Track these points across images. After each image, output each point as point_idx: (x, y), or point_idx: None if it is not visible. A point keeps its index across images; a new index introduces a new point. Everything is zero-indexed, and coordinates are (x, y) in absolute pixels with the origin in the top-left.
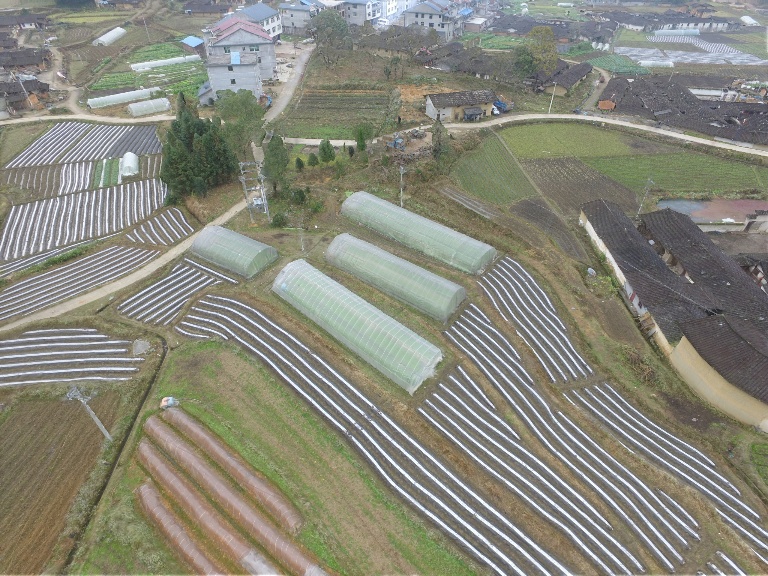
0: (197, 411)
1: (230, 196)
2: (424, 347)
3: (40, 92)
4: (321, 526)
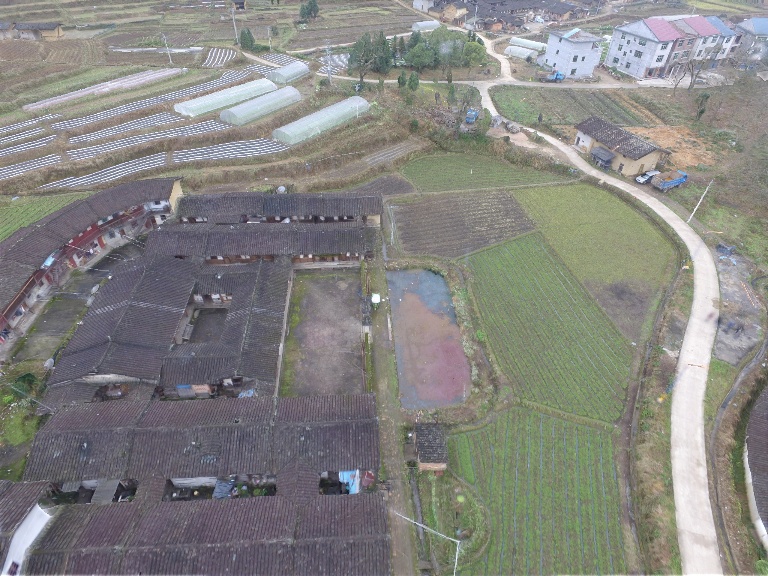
0: None
1: None
2: (192, 104)
3: (511, 25)
4: (121, 90)
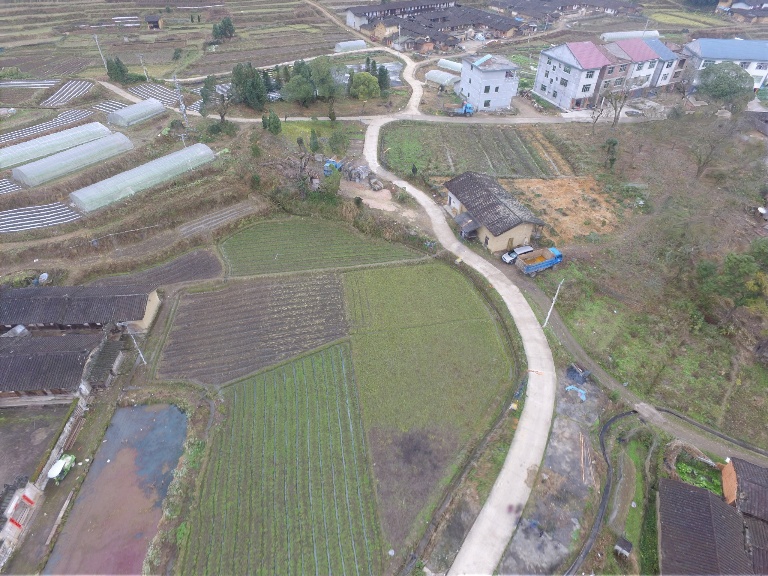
0: (1, 116)
1: (233, 112)
2: None
3: (444, 45)
4: None
